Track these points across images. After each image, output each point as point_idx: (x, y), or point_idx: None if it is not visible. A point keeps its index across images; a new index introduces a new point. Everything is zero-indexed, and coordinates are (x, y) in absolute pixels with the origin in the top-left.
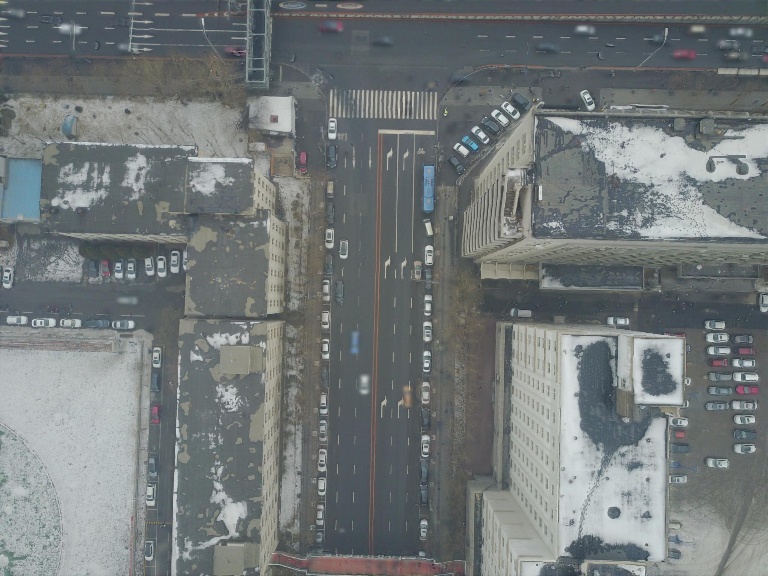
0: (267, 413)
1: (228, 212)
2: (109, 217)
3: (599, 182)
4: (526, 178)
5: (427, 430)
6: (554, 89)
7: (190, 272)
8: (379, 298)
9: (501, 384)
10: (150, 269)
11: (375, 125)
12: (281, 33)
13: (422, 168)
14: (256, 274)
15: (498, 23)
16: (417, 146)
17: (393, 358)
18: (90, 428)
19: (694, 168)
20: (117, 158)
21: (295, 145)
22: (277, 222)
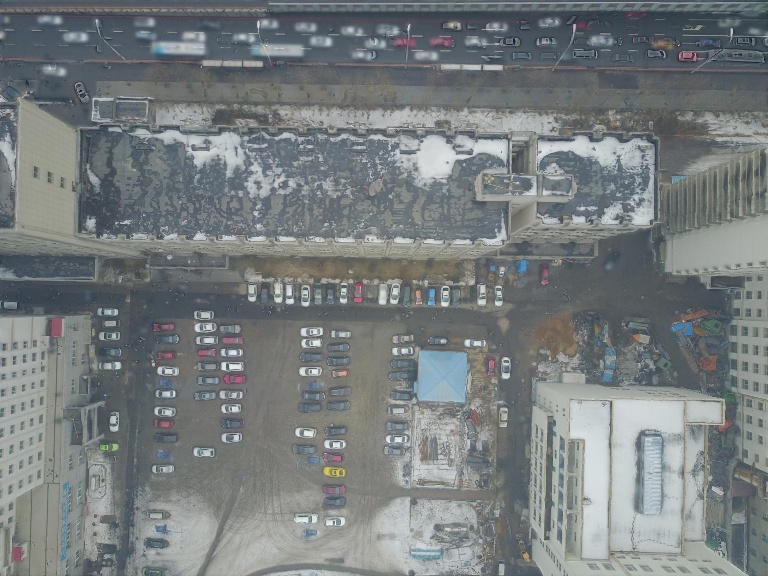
0: None
1: None
2: None
3: None
4: None
5: None
6: (51, 82)
7: None
8: None
9: None
10: None
11: None
12: None
13: None
14: None
15: None
16: None
17: None
18: None
19: None
20: None
21: None
22: None
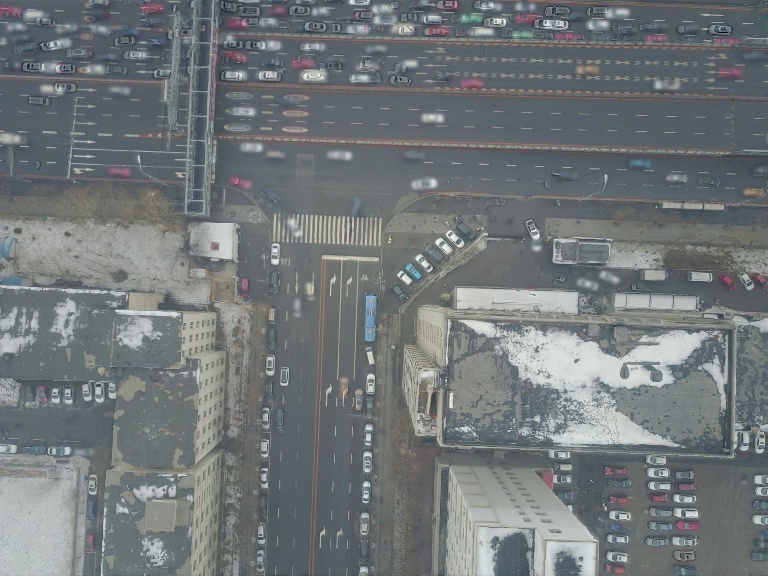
0: (197, 559)
1: (155, 366)
2: (37, 363)
3: (512, 387)
4: (439, 381)
5: (365, 562)
6: (499, 217)
7: (118, 422)
8: (320, 426)
9: (437, 526)
10: (87, 395)
11: (319, 251)
12: (225, 155)
13: (364, 297)
14: (185, 425)
15: (444, 150)
16: (361, 272)
17: (333, 487)
18: (24, 555)
19: (608, 374)
20: (46, 303)
21: (237, 270)
22: (213, 359)
